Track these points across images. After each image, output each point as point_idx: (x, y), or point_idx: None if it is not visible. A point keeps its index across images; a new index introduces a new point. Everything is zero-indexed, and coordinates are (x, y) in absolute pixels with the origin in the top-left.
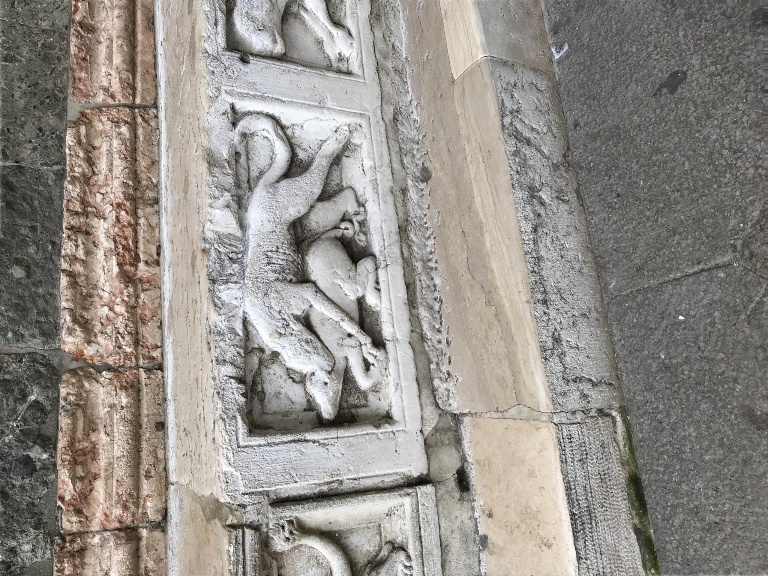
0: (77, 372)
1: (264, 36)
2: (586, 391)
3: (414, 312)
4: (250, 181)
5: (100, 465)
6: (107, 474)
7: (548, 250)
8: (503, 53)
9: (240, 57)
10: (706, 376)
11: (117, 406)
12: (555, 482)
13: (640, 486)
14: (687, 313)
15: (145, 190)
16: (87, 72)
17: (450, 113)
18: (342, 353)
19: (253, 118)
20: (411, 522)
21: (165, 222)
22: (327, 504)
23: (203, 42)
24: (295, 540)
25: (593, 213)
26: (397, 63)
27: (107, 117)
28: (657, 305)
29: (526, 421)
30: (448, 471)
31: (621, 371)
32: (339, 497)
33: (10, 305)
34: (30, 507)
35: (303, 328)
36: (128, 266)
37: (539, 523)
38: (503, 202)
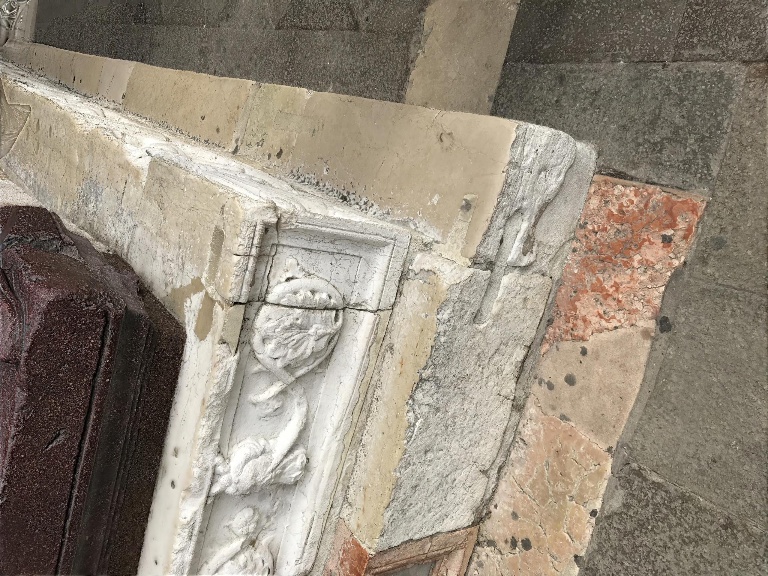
0: None
1: None
2: None
3: None
4: None
5: None
6: None
7: None
8: None
9: None
10: None
11: None
12: None
13: None
14: None
15: None
16: None
17: None
18: None
19: None
20: None
21: None
22: None
23: None
24: None
25: None
26: None
27: None
28: None
29: None
30: None
31: None
32: None
33: None
34: None
35: None
36: None
37: None
38: None
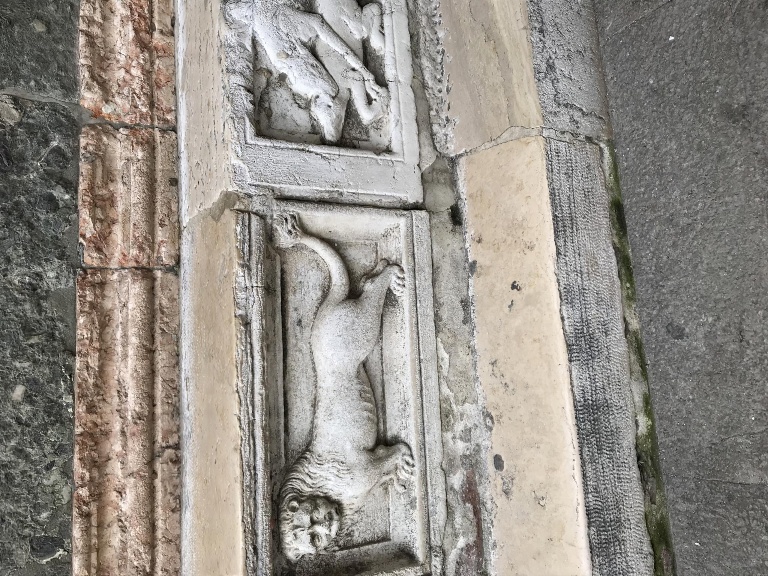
0: (96, 126)
1: None
2: (576, 117)
3: (417, 61)
4: None
5: (118, 211)
6: (125, 218)
7: None
8: None
9: None
10: (690, 87)
11: (134, 159)
12: (540, 188)
13: (622, 211)
14: (677, 32)
15: None
16: None
17: None
18: (346, 84)
19: None
20: (405, 239)
21: None
22: (327, 207)
23: None
24: (297, 236)
25: None
26: None
27: None
28: (650, 33)
29: (517, 140)
30: (442, 205)
31: (612, 108)
32: (339, 204)
33: (32, 55)
34: (54, 239)
35: (309, 53)
36: (144, 32)
37: (524, 230)
38: None
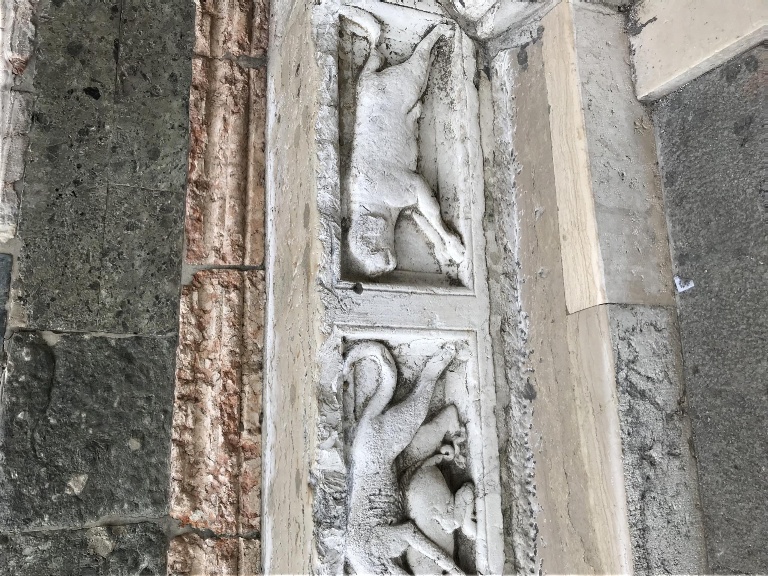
0: (183, 539)
1: (377, 260)
2: None
3: (509, 539)
4: (356, 409)
5: None
6: None
7: (654, 518)
8: (623, 297)
9: (353, 287)
10: None
11: (218, 575)
12: None
13: None
14: None
15: (250, 355)
16: (201, 233)
17: (561, 345)
18: None
19: (362, 347)
20: None
21: (269, 398)
22: None
23: (318, 273)
24: None
25: (705, 469)
26: (508, 269)
27: (218, 280)
28: None
29: None
30: None
31: None
32: None
33: (126, 477)
34: None
35: (400, 572)
36: (232, 435)
37: None
38: (611, 465)
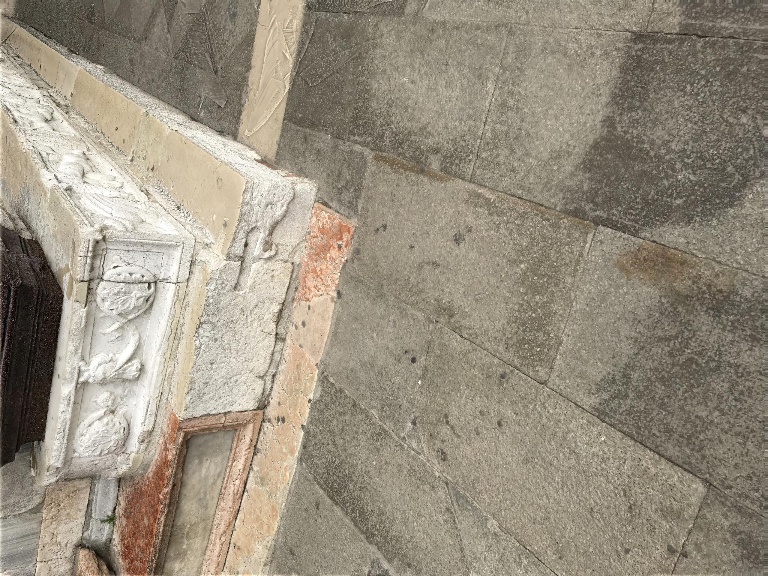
0: None
1: None
2: None
3: None
4: None
5: None
6: None
7: None
8: None
9: None
10: None
11: None
12: None
13: None
14: None
15: None
16: None
17: None
18: None
19: None
20: None
21: None
22: None
23: None
24: None
25: None
26: None
27: None
28: None
29: None
30: None
31: None
32: None
33: None
34: None
35: None
36: None
37: None
38: None
